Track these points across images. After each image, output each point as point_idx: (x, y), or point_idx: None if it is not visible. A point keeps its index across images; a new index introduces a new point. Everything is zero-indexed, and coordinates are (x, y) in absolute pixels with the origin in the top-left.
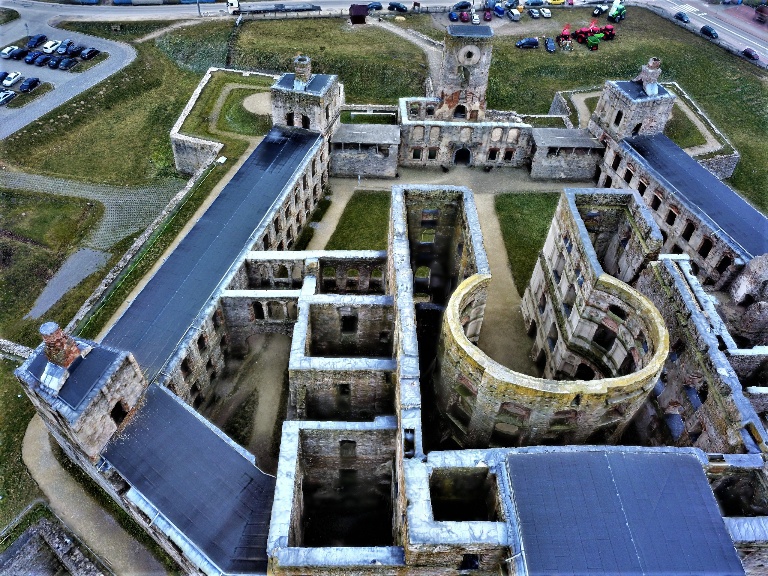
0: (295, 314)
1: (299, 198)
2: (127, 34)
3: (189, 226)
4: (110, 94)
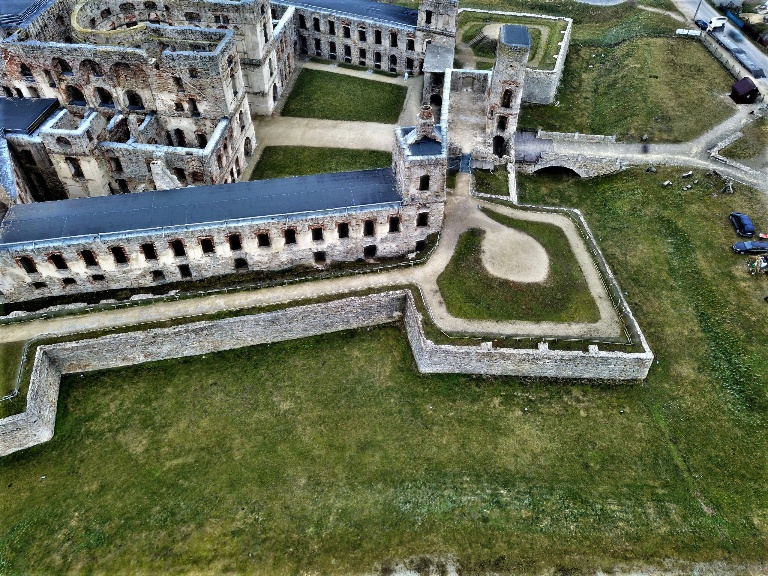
0: None
1: (367, 40)
2: (649, 0)
3: None
4: (548, 5)
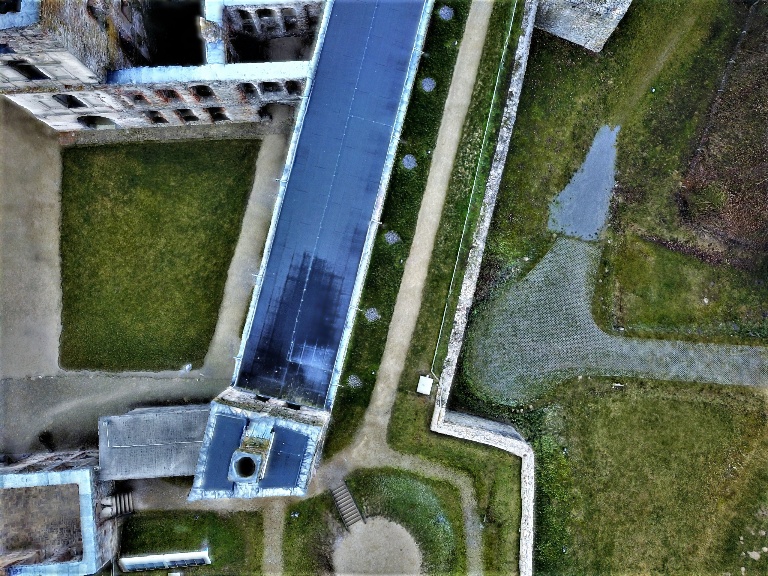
0: (269, 105)
1: None
2: None
3: (435, 215)
4: None
